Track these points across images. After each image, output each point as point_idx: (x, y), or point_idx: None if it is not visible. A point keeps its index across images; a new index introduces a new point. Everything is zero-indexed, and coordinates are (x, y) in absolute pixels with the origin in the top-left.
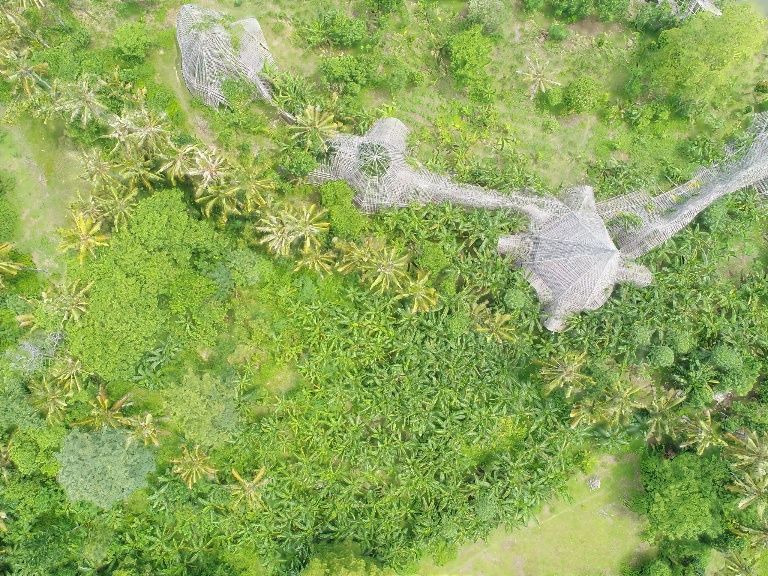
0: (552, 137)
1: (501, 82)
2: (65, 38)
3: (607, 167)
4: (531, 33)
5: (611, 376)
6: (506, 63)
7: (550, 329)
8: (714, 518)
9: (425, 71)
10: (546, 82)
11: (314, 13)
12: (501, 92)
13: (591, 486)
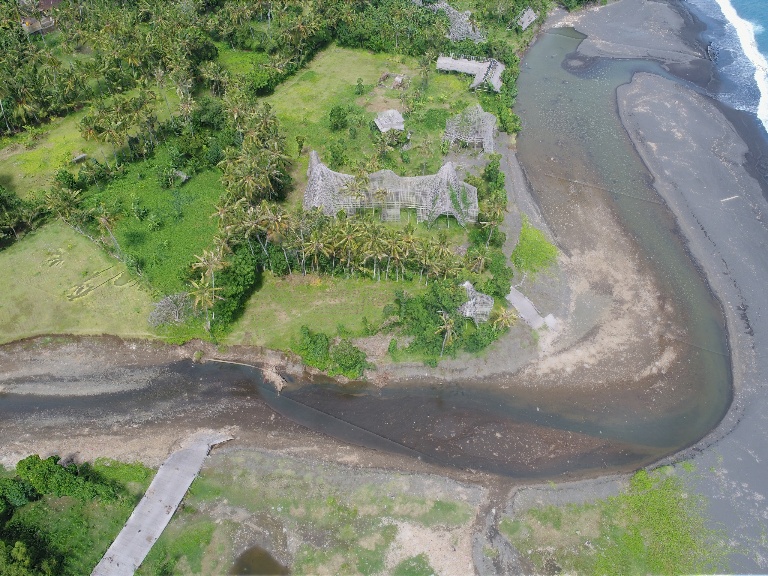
0: None
1: None
2: None
3: None
4: None
5: None
6: None
7: None
8: None
9: None
10: None
11: None
12: None
13: None
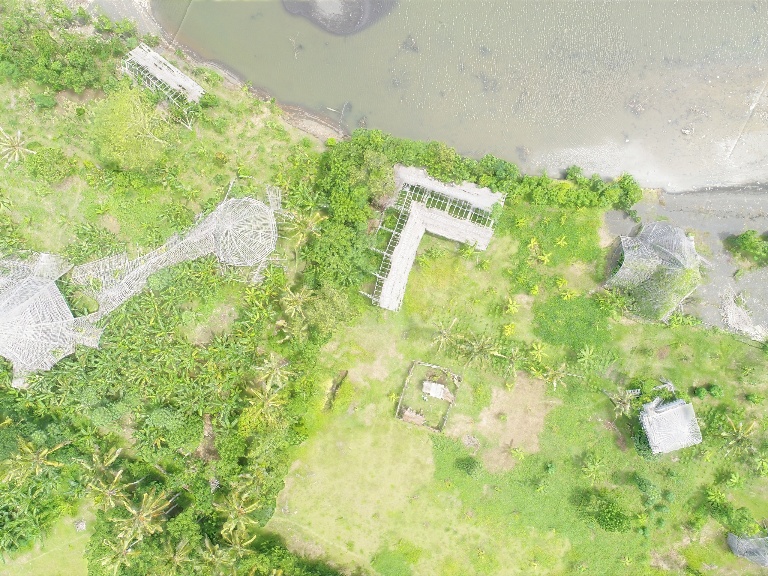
0: (46, 200)
1: None
2: None
3: None
4: (25, 100)
5: (36, 436)
6: None
7: (13, 386)
8: (129, 568)
9: None
10: None
11: None
12: None
13: (76, 528)
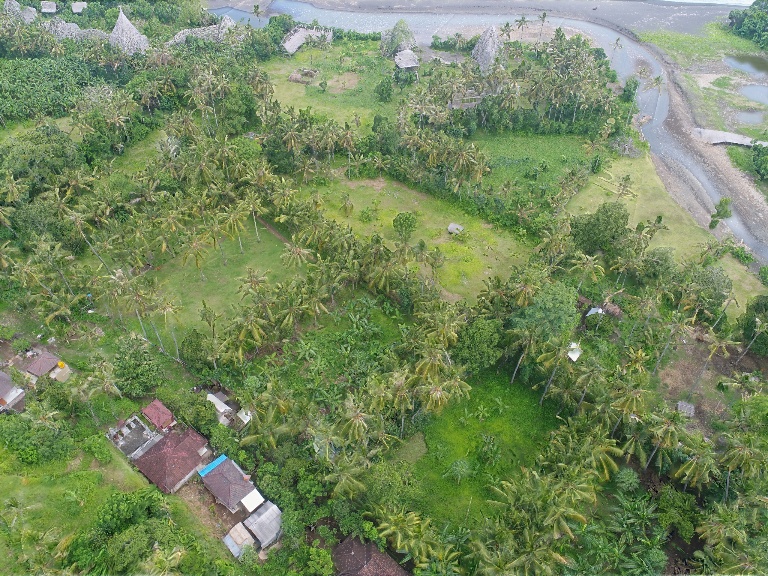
0: None
1: None
2: None
3: None
4: None
5: None
6: None
7: None
8: None
9: None
10: None
11: None
12: None
13: None
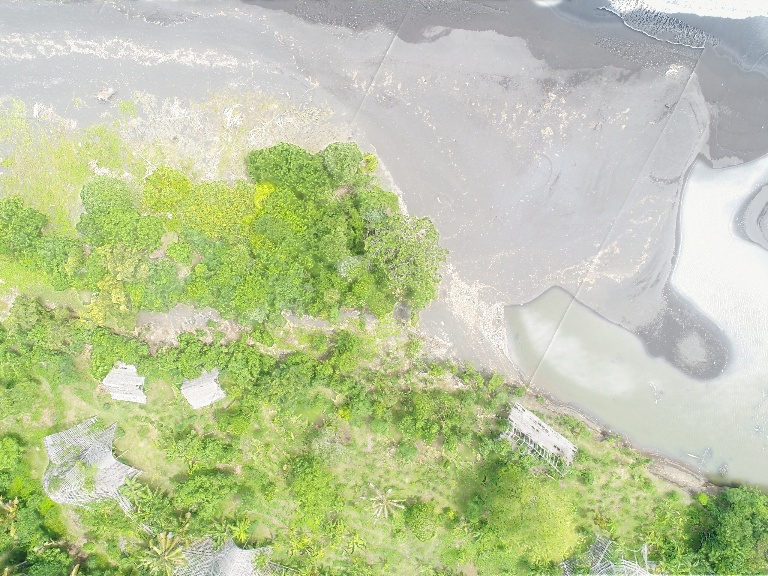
0: (401, 543)
1: (353, 489)
2: None
3: (453, 574)
4: (383, 444)
5: None
6: (358, 472)
7: None
8: None
9: (281, 476)
10: (390, 505)
11: (177, 417)
12: (353, 499)
13: None
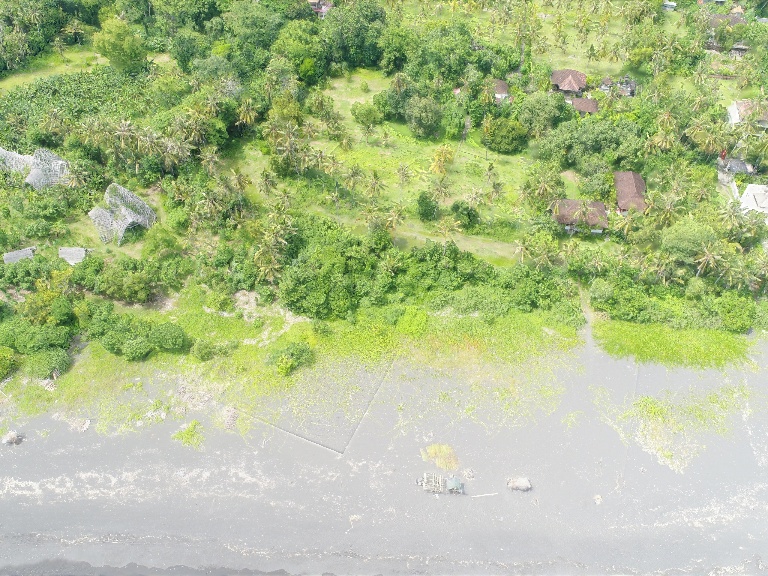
0: None
1: None
2: (228, 234)
3: None
4: None
5: None
6: None
7: None
8: None
9: (2, 225)
10: None
11: None
12: None
13: None
